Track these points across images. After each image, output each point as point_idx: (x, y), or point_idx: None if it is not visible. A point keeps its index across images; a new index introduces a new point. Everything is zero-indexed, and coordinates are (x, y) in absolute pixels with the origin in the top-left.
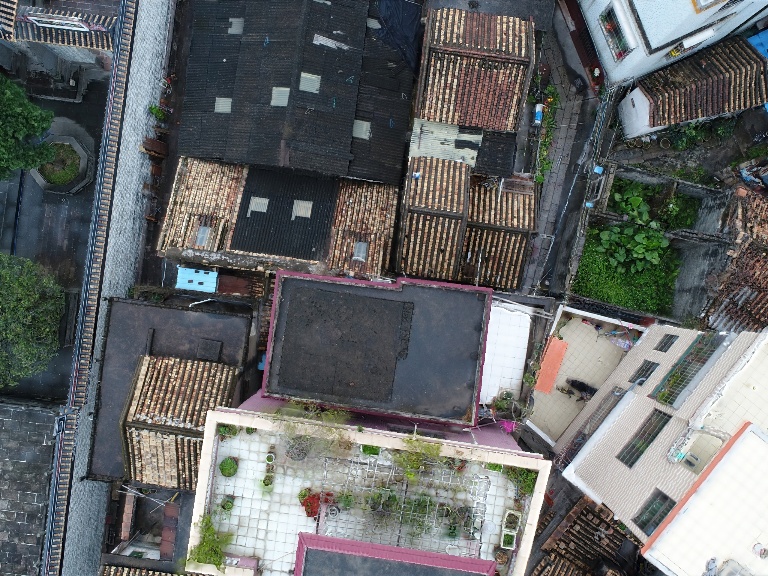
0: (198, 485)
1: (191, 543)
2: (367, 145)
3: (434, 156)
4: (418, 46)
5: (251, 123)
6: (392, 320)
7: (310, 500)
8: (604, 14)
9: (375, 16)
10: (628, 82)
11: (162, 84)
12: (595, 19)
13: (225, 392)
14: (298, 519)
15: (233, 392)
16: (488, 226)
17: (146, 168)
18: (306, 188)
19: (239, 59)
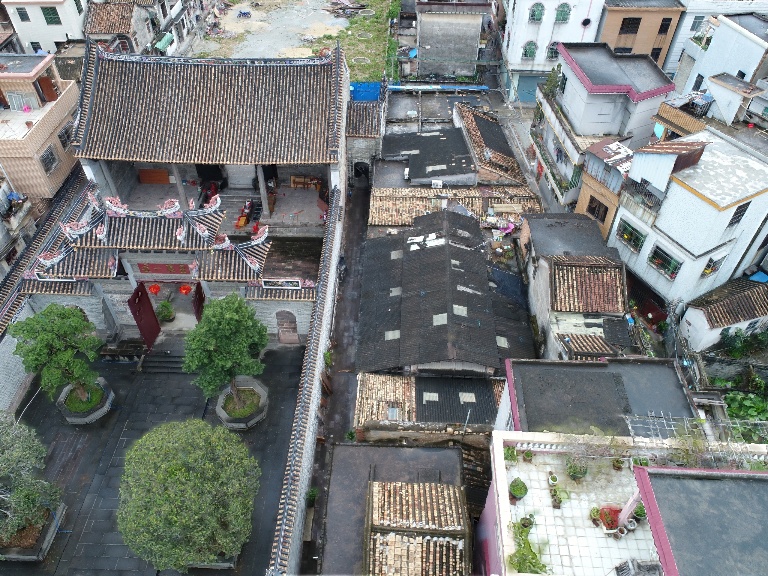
0: (500, 494)
1: (507, 553)
2: (508, 351)
3: (572, 333)
4: (524, 297)
5: (419, 339)
6: (608, 385)
7: (606, 509)
8: (651, 255)
9: (492, 280)
10: (679, 309)
11: (328, 344)
12: (642, 267)
13: (457, 503)
14: (597, 541)
15: (465, 502)
16: None
17: (319, 397)
18: (465, 386)
19: (402, 306)
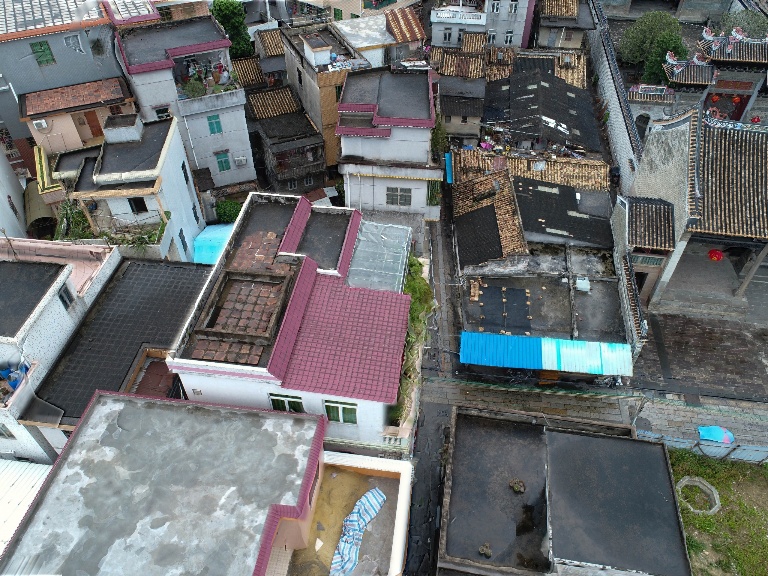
0: None
1: None
2: (502, 85)
3: None
4: None
5: None
6: None
7: None
8: None
9: None
10: None
11: None
12: None
13: (545, 7)
14: None
15: None
16: (451, 47)
17: None
18: None
19: None
